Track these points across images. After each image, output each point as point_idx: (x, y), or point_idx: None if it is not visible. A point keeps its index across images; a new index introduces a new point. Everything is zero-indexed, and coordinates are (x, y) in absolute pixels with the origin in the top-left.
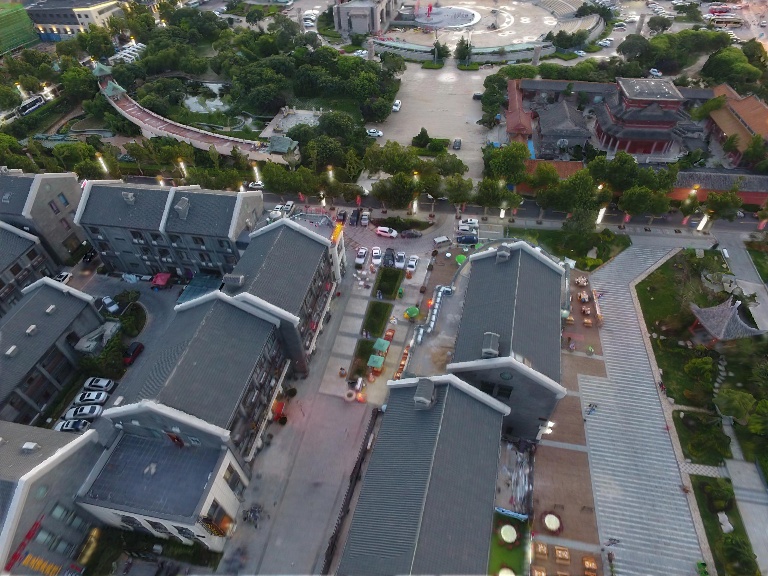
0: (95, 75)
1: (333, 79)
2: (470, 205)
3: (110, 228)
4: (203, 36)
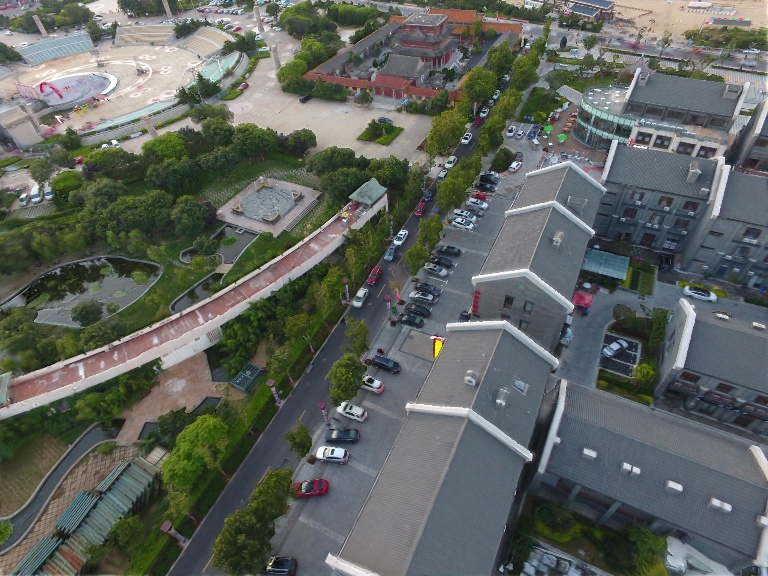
0: None
1: (224, 149)
2: None
3: None
4: None
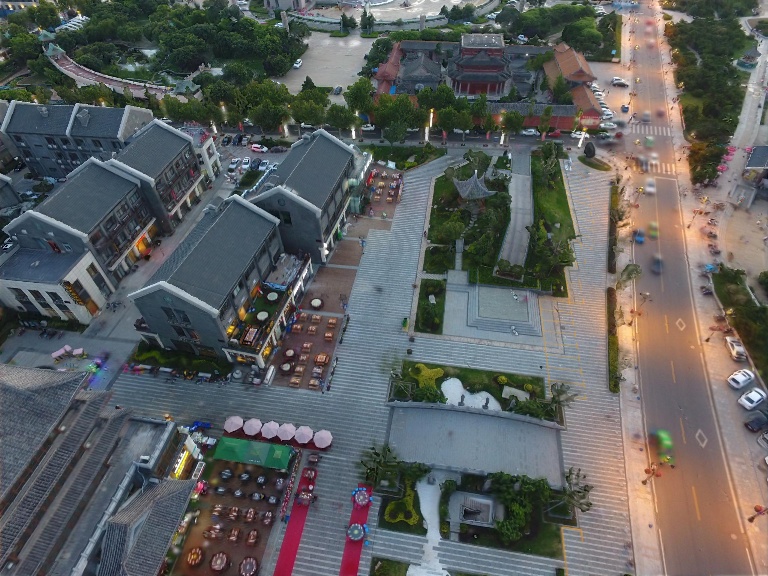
0: (40, 40)
1: (243, 41)
2: (333, 131)
3: (29, 135)
4: (143, 11)
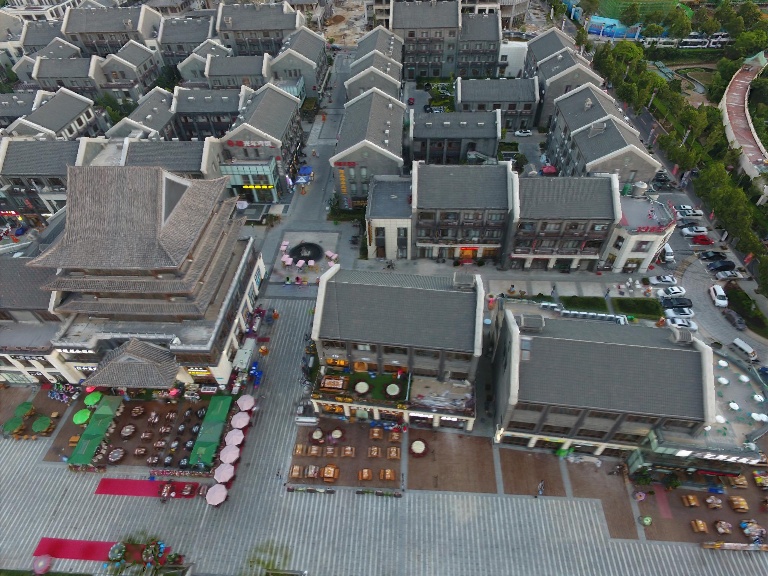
0: (767, 45)
1: None
2: None
3: None
4: None
